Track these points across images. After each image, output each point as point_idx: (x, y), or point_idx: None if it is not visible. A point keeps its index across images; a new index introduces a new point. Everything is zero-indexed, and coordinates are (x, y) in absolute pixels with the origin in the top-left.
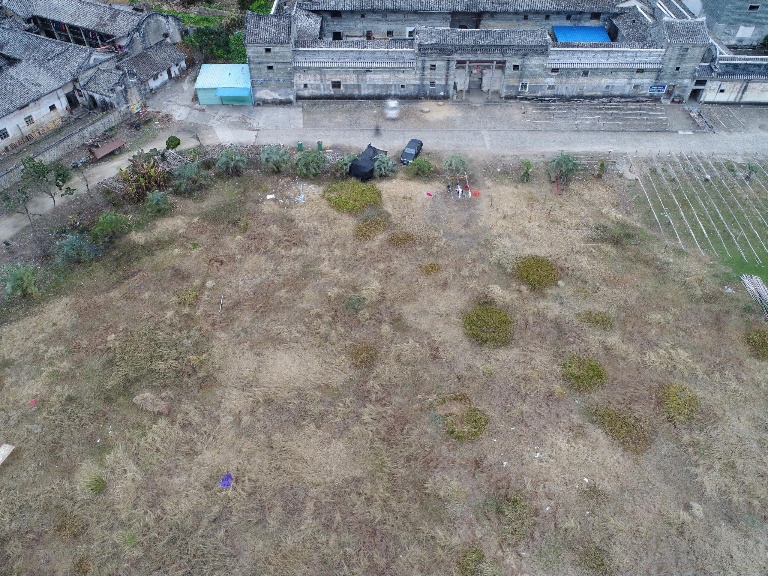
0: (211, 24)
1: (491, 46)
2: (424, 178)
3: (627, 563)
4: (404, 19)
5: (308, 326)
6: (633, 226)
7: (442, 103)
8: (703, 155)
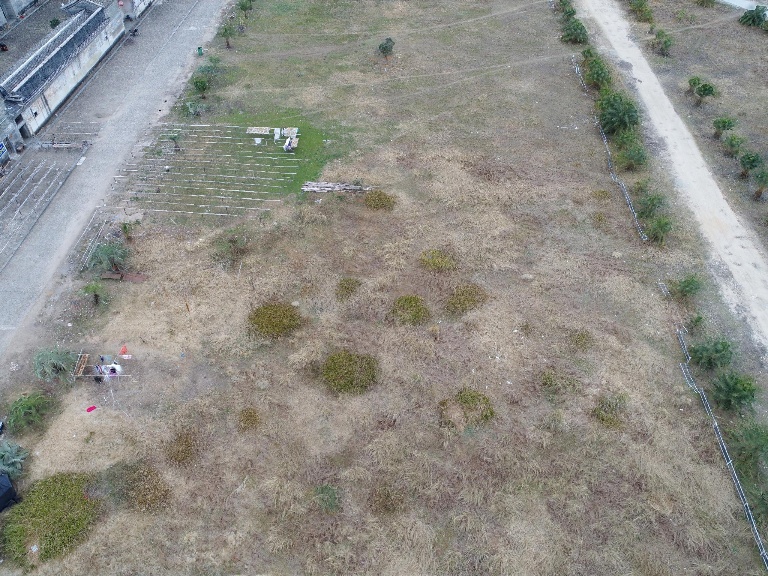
0: None
1: None
2: (49, 412)
3: (577, 322)
4: None
5: (337, 575)
6: (220, 235)
7: None
8: (126, 161)
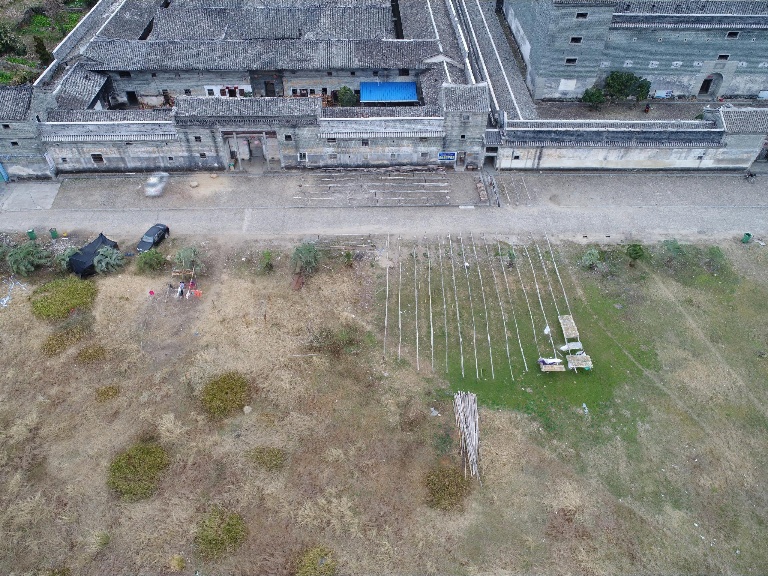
0: (5, 81)
1: (255, 117)
2: (155, 272)
3: None
4: (199, 77)
5: None
6: (362, 329)
7: (215, 175)
8: (475, 235)
